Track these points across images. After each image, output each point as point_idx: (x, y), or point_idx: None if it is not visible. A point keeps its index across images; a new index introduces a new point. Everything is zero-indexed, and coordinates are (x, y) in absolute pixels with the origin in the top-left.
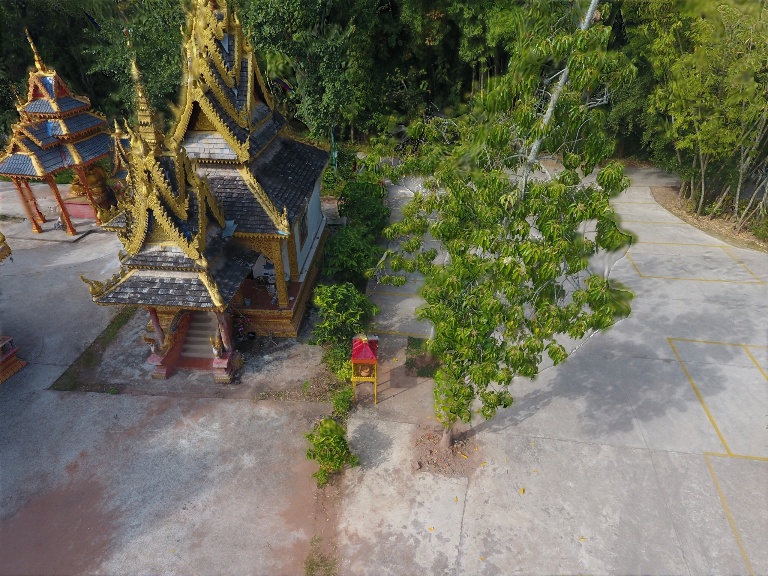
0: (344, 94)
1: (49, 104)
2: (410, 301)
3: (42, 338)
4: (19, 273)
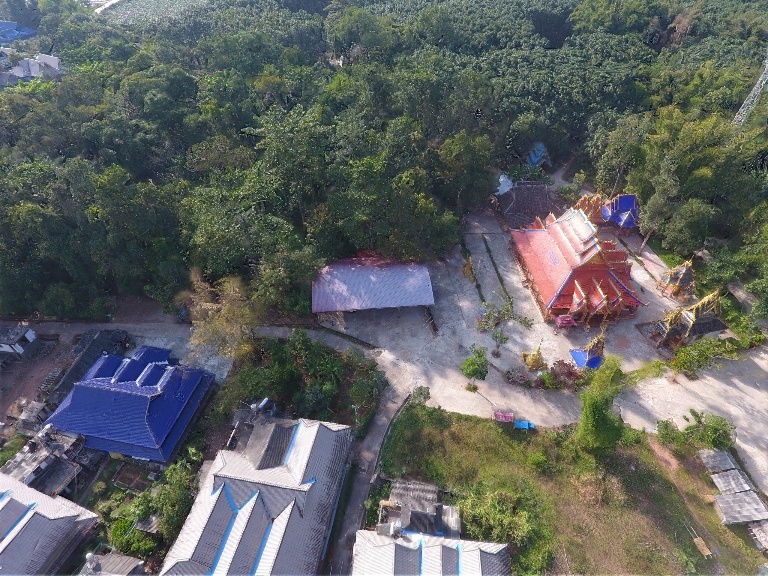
0: (762, 317)
1: None
2: (705, 368)
3: (639, 316)
4: (645, 298)
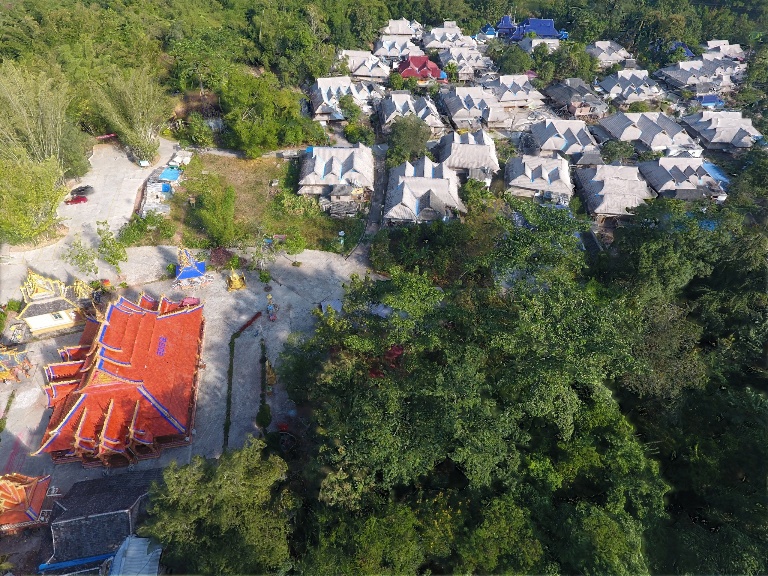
0: None
1: None
2: None
3: None
4: None
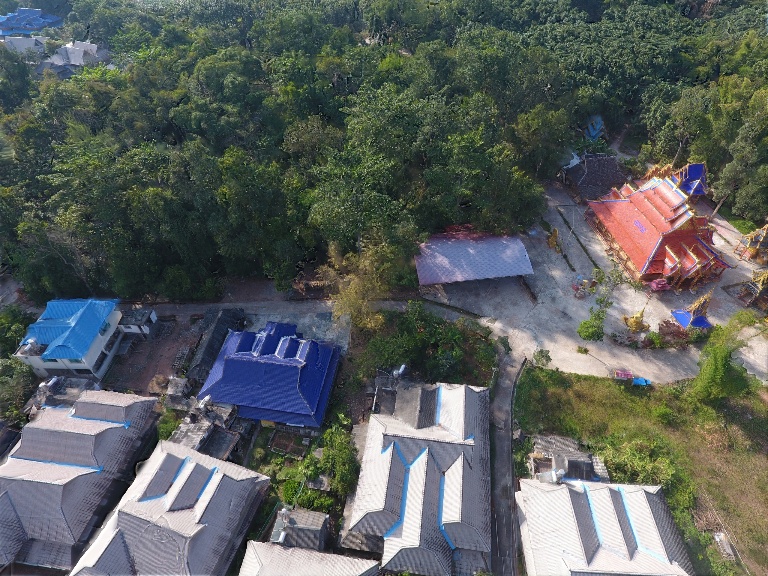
0: None
1: (764, 233)
2: None
3: (723, 278)
4: None
